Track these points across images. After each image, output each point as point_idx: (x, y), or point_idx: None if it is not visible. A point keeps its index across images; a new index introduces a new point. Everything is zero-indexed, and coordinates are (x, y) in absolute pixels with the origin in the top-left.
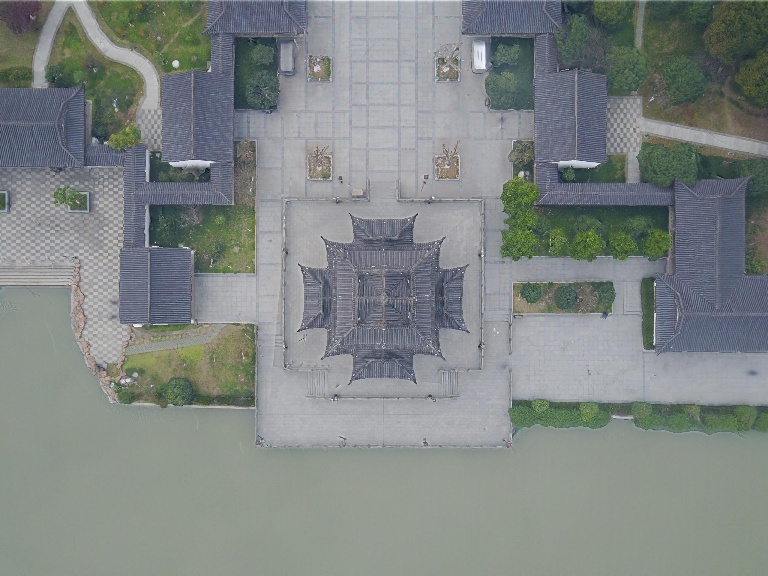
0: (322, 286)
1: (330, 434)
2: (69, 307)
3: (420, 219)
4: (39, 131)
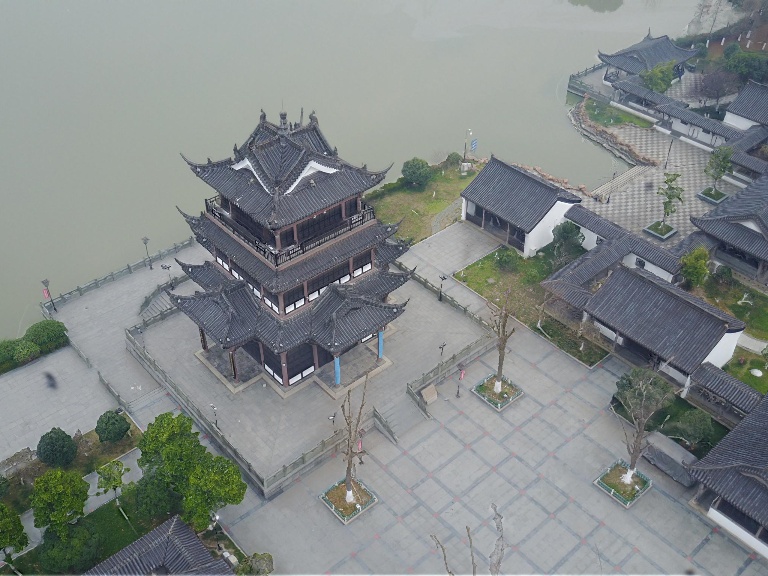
0: None
1: None
2: (569, 183)
3: None
4: (759, 207)
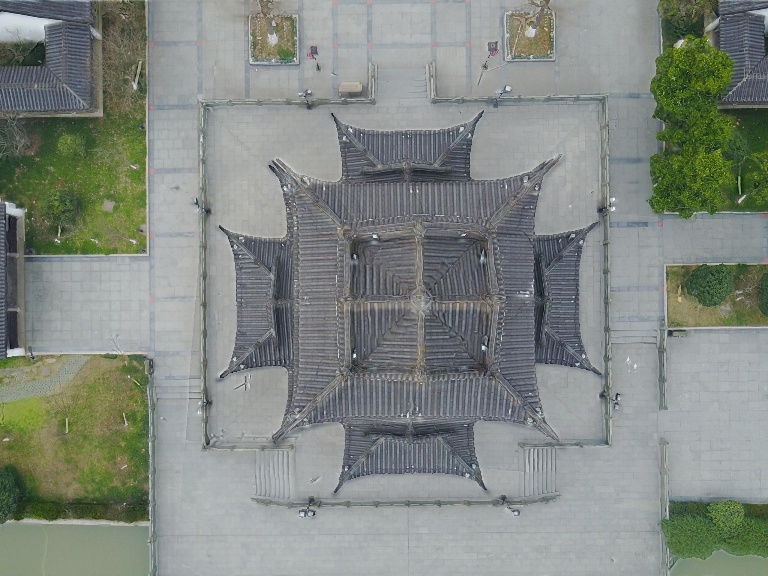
0: (273, 275)
1: (301, 574)
2: None
3: (477, 139)
4: None
